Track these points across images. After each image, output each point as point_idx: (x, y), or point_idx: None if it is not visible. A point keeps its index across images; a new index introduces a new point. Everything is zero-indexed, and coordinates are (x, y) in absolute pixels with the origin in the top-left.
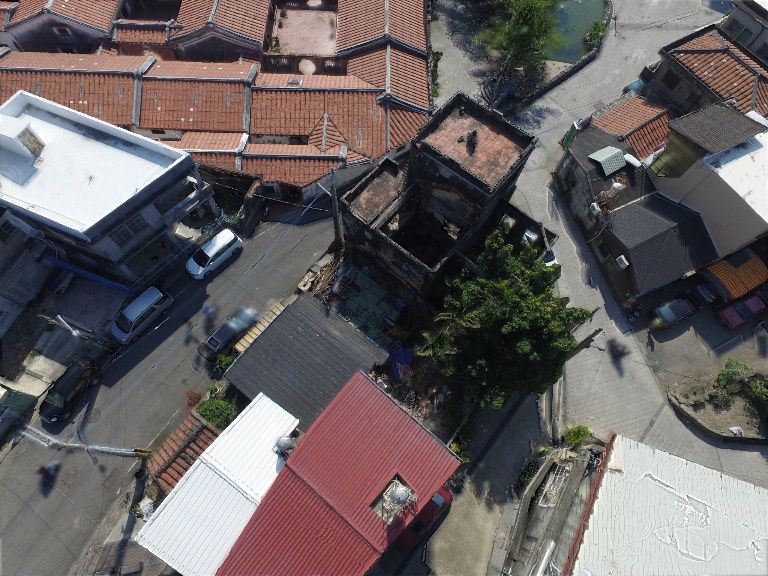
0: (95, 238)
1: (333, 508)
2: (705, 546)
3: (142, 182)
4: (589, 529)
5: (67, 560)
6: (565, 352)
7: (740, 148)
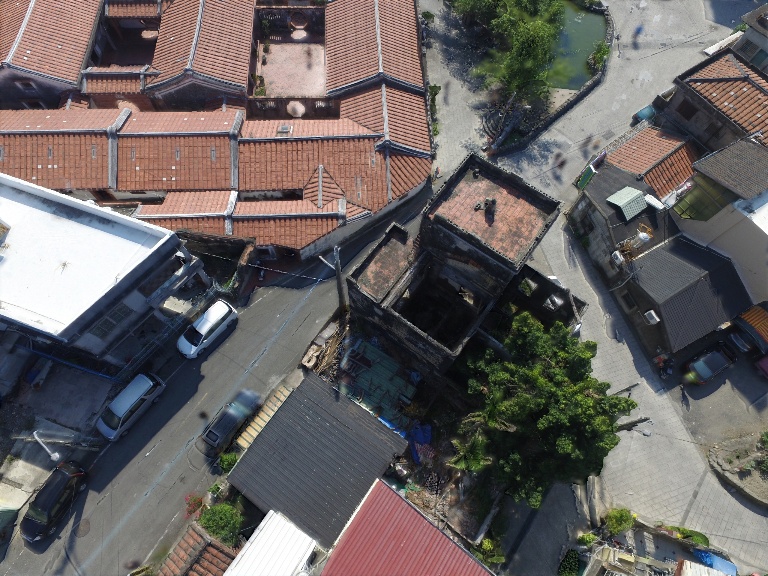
0: (72, 337)
1: None
2: None
3: (122, 266)
4: None
5: None
6: None
7: None
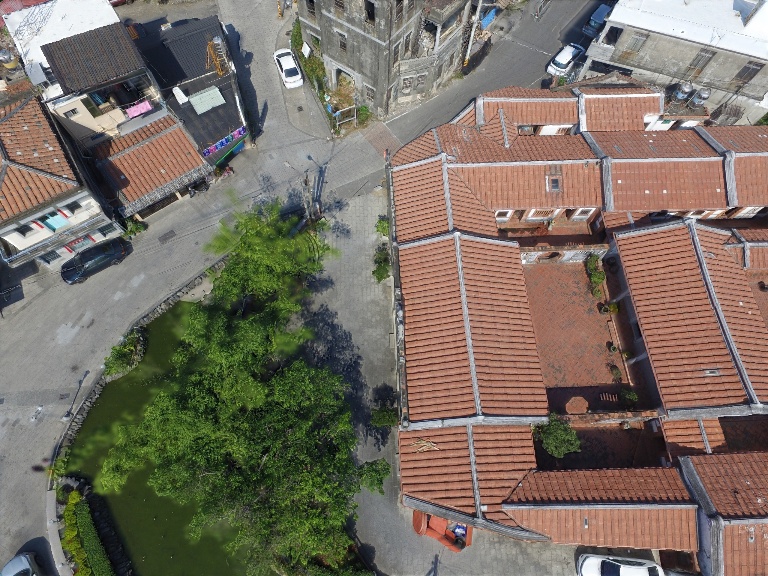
0: None
1: None
2: None
3: (644, 3)
4: None
5: None
6: None
7: None
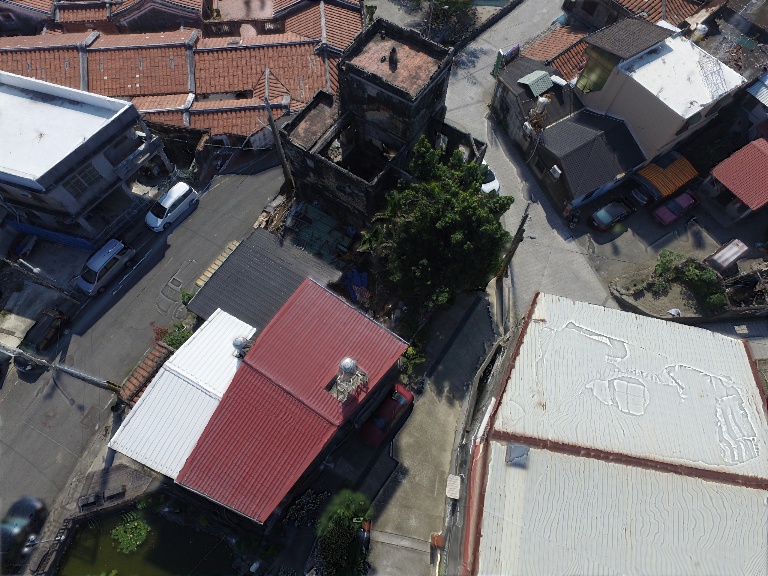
0: (49, 187)
1: (290, 393)
2: (644, 404)
3: None
4: (515, 367)
5: (52, 492)
6: (496, 239)
7: (652, 54)
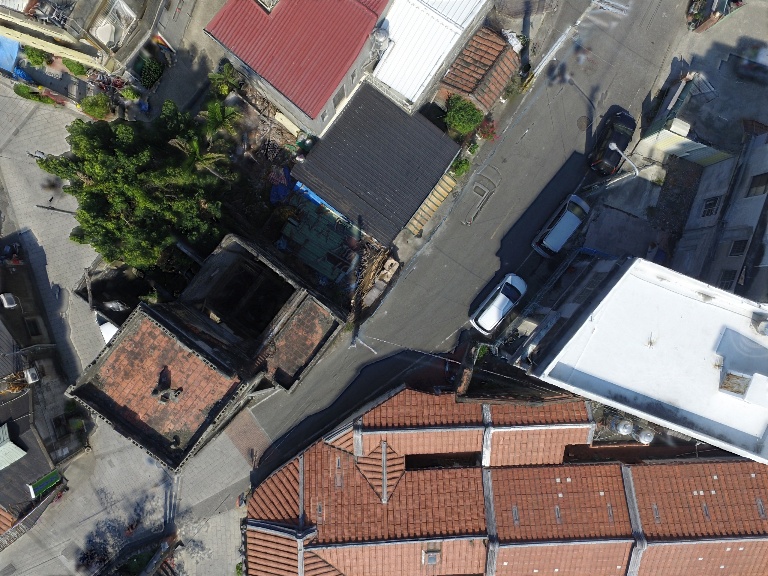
0: (624, 262)
1: None
2: None
3: (590, 342)
4: None
5: (573, 0)
6: None
7: None
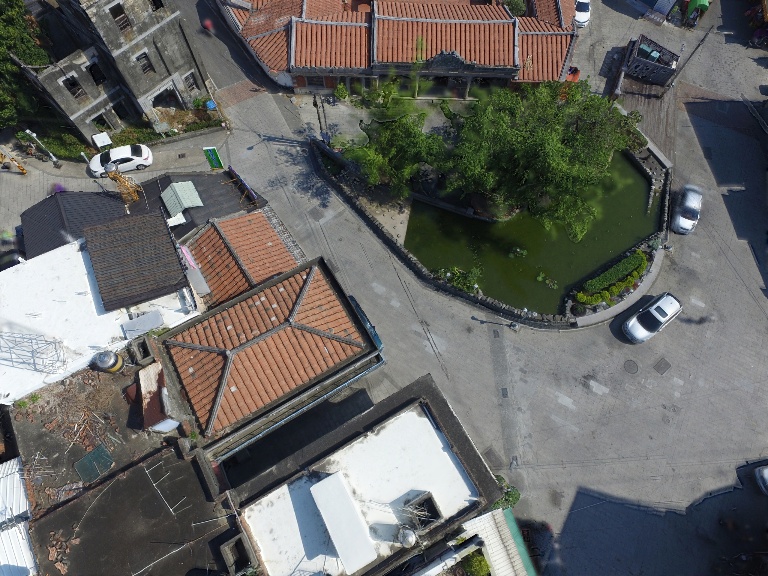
0: None
1: None
2: None
3: None
4: None
5: None
6: None
7: None
